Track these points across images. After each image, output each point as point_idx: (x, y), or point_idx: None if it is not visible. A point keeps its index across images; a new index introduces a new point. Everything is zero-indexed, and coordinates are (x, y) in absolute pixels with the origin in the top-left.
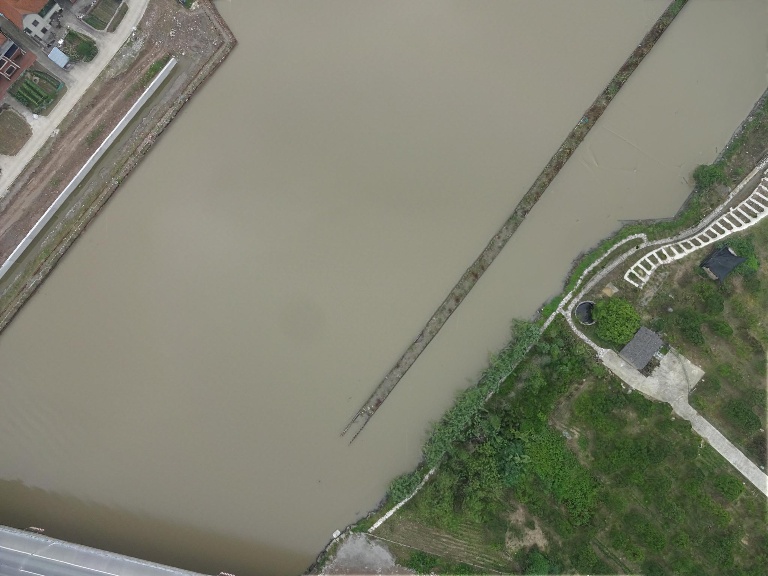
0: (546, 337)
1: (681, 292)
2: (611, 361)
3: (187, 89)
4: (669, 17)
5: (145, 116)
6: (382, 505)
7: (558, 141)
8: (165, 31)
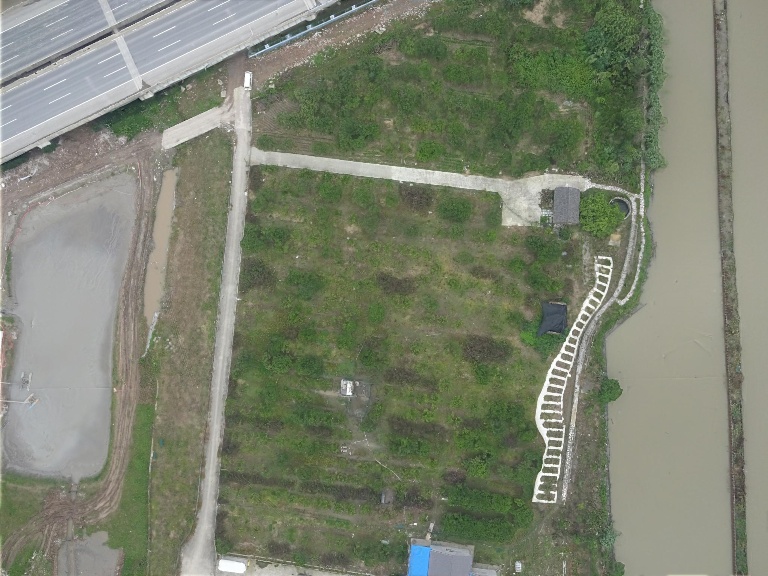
0: None
1: None
2: (577, 182)
3: None
4: (739, 514)
5: None
6: None
7: None
8: None
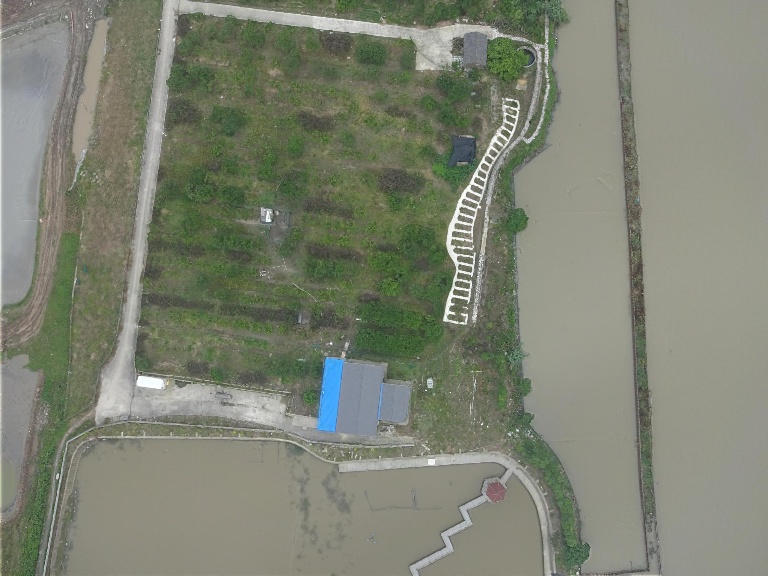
0: None
1: None
2: (486, 32)
3: None
4: (639, 334)
5: None
6: None
7: None
8: None
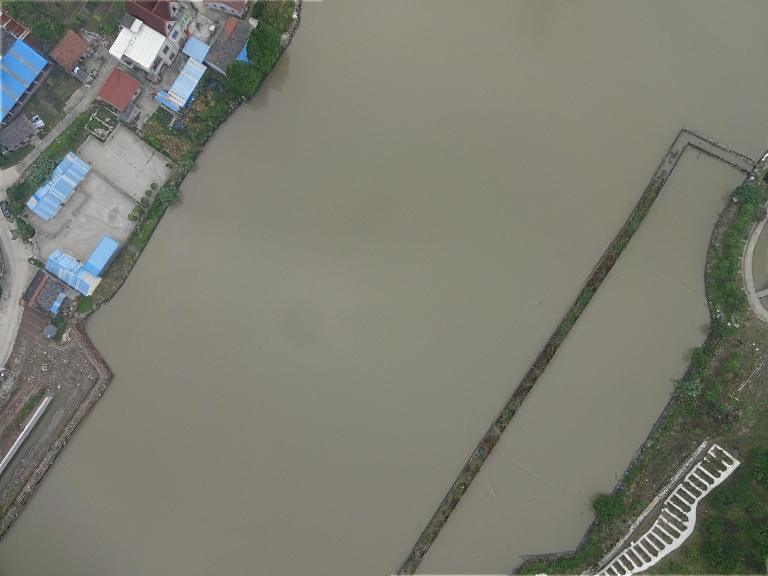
0: None
1: None
2: None
3: (64, 431)
4: (562, 335)
5: (23, 457)
6: None
7: (453, 473)
8: (36, 366)
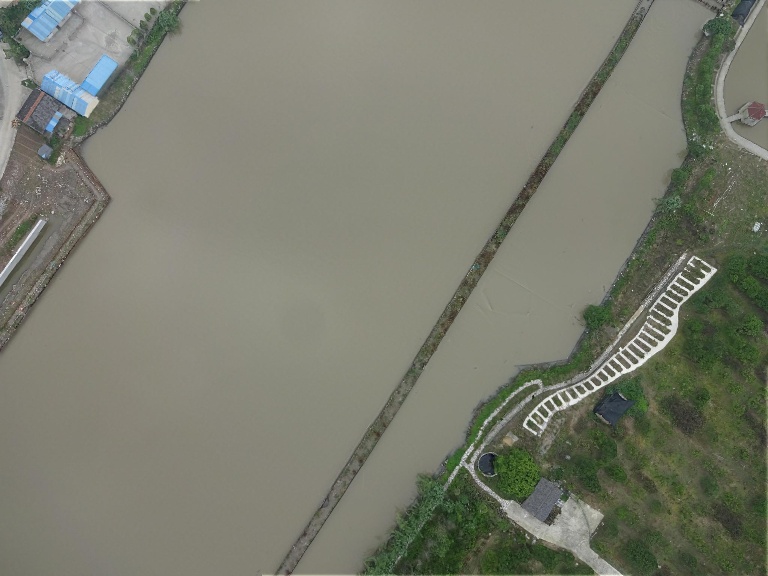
0: (450, 494)
1: (577, 438)
2: (515, 513)
3: (59, 253)
4: (552, 157)
5: (15, 283)
6: None
7: (451, 288)
8: (30, 189)
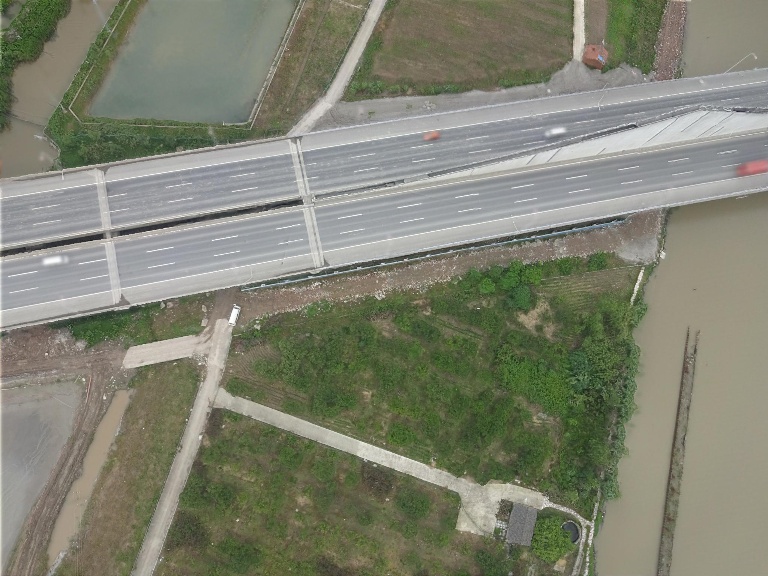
0: None
1: None
2: (536, 499)
3: None
4: None
5: None
6: (642, 291)
7: None
8: None
